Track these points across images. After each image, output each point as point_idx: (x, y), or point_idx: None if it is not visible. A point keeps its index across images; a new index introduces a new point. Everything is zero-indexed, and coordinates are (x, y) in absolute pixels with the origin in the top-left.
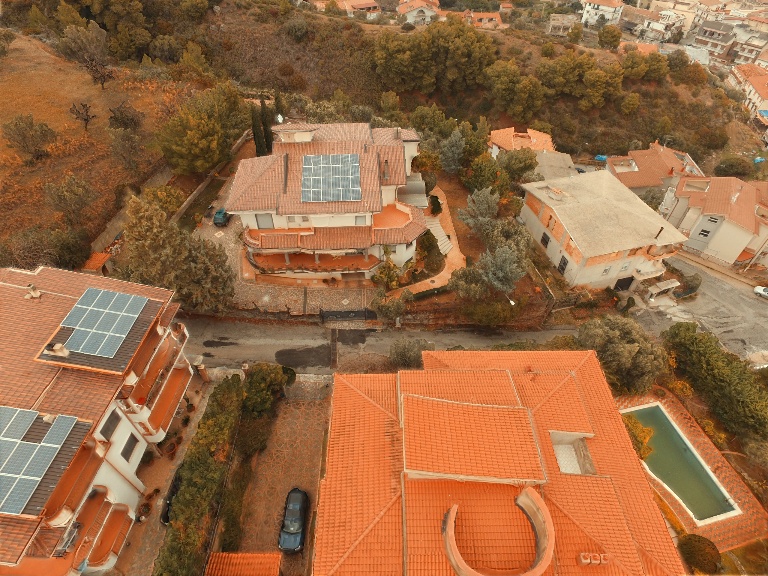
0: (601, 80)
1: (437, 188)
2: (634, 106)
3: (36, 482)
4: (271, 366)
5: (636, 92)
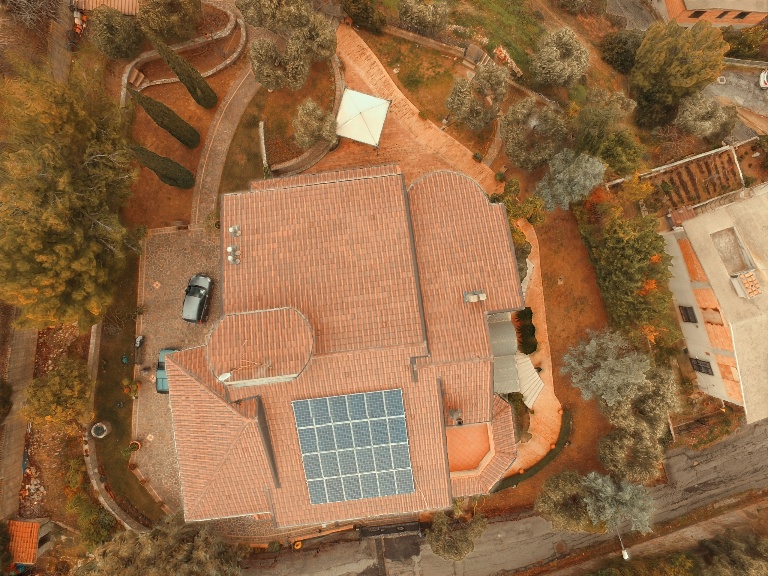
0: None
1: (524, 220)
2: None
3: None
4: None
5: None
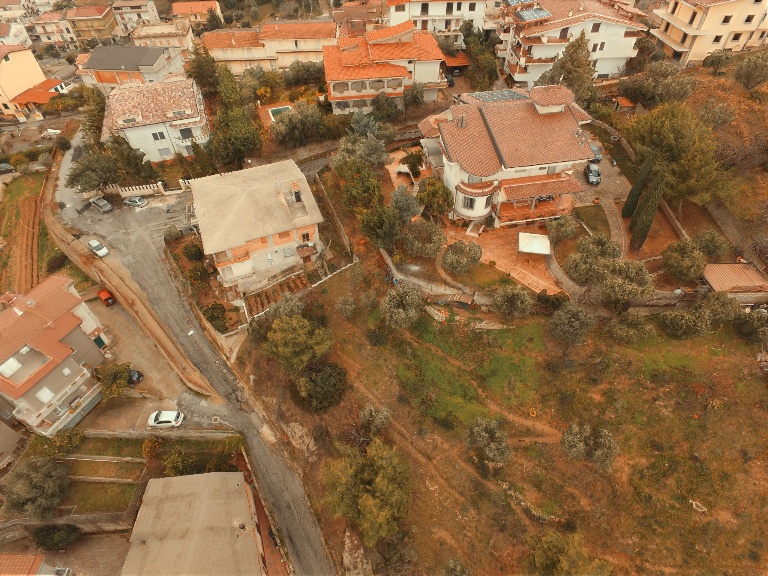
0: None
1: None
2: None
3: (508, 0)
4: None
5: None
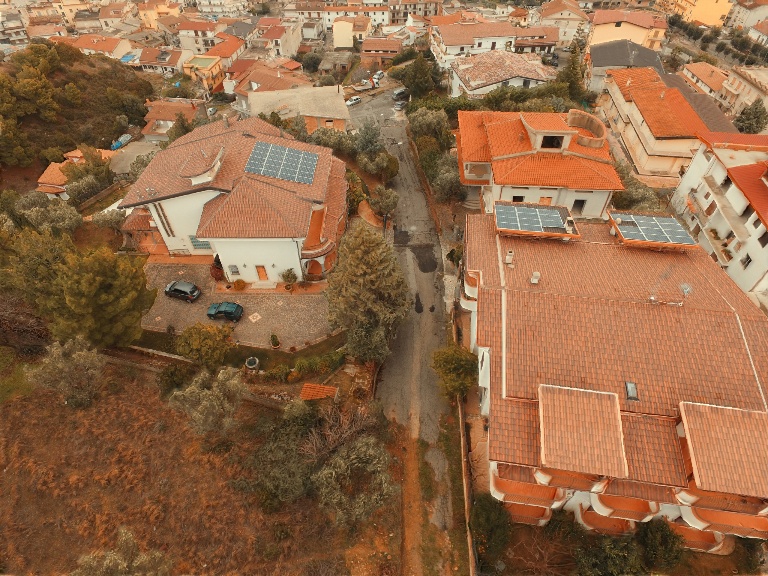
0: (38, 86)
1: None
2: (80, 94)
3: None
4: (458, 251)
5: (58, 86)
